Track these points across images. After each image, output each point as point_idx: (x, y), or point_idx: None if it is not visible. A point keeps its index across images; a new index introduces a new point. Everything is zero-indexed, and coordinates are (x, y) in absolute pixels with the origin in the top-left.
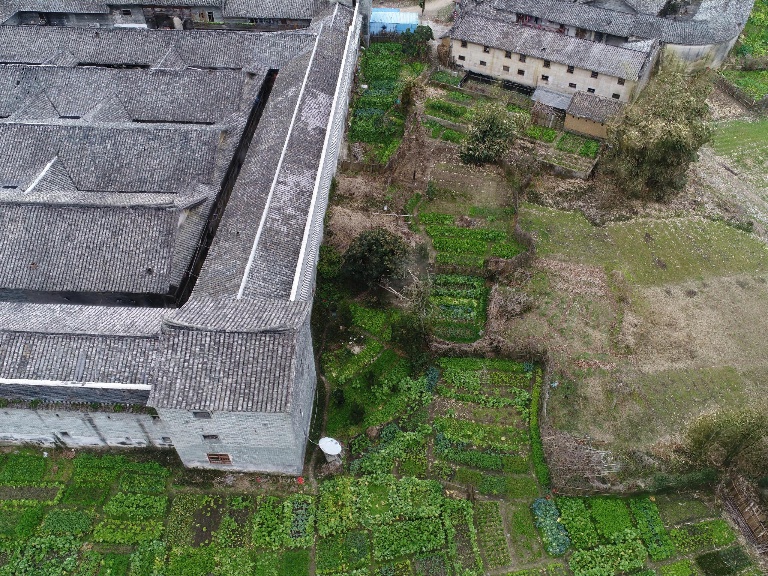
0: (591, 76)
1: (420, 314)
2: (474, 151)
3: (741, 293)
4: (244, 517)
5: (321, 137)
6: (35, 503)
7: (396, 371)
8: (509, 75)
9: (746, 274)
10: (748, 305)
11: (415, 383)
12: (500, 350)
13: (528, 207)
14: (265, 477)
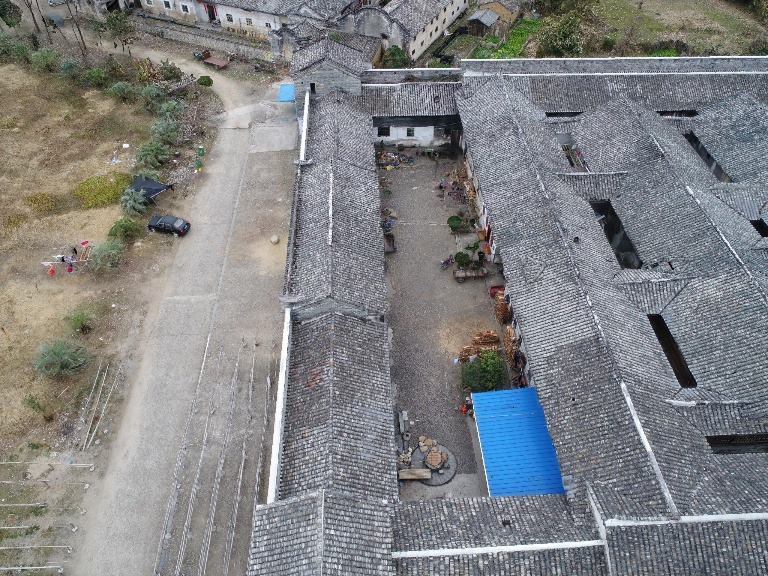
0: None
1: None
2: None
3: (646, 4)
4: None
5: None
6: None
7: None
8: (432, 38)
9: (628, 2)
10: (654, 4)
11: None
12: None
13: None
14: None
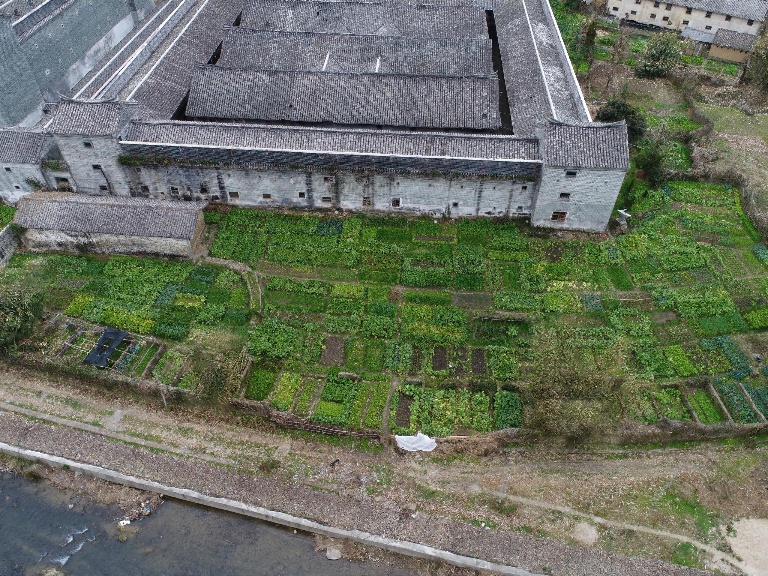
0: (725, 19)
1: (662, 147)
2: (650, 67)
3: None
4: (576, 251)
5: (553, 49)
6: (444, 242)
7: (641, 187)
8: (655, 21)
9: None
10: None
11: (657, 192)
12: (710, 175)
13: (696, 104)
14: (581, 233)
